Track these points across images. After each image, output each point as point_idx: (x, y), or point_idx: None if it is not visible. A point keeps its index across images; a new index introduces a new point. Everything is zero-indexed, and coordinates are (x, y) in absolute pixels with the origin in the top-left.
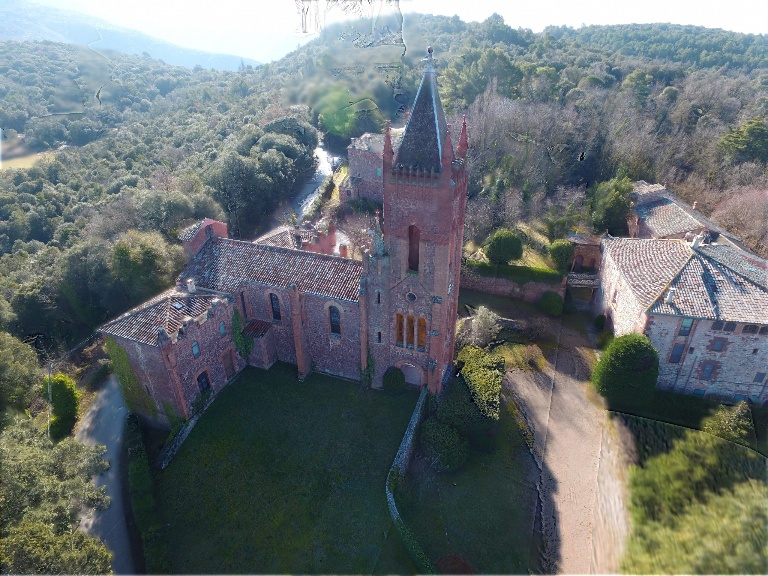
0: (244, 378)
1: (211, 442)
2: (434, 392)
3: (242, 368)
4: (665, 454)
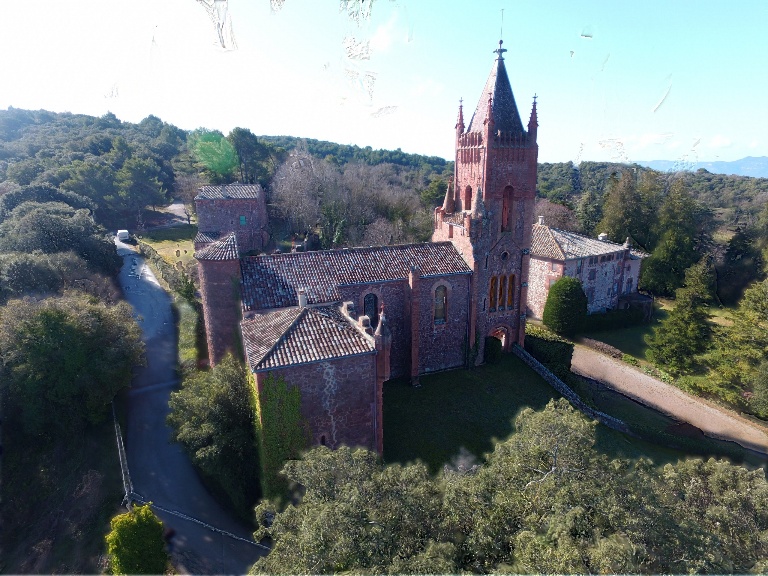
0: None
1: None
2: (523, 346)
3: None
4: None
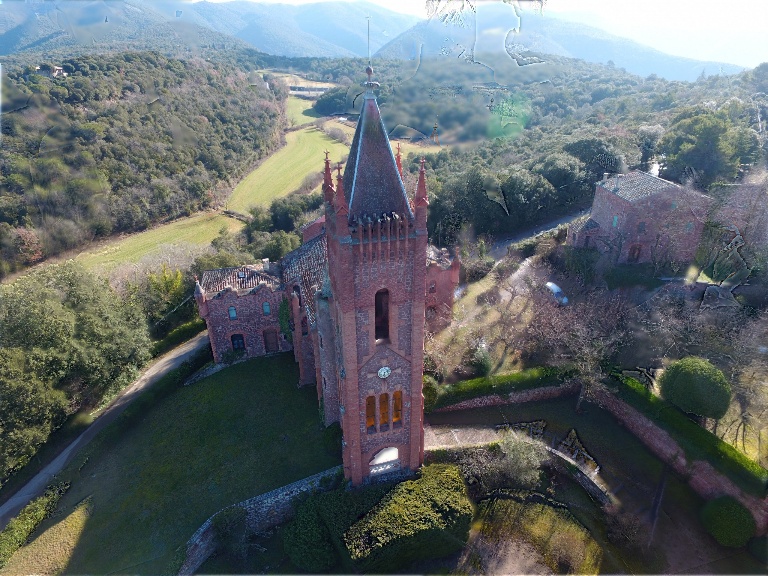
0: (278, 358)
1: (211, 387)
2: (346, 477)
3: (287, 350)
4: None
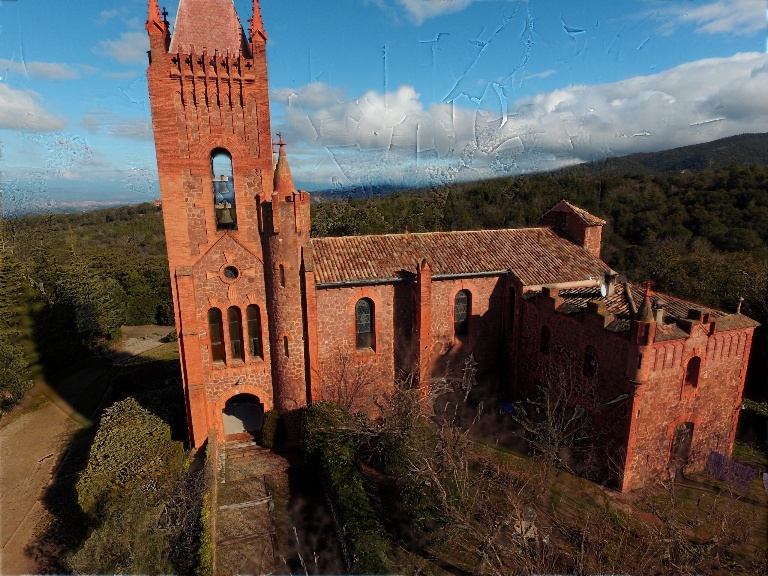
0: None
1: None
2: None
3: None
4: (65, 136)
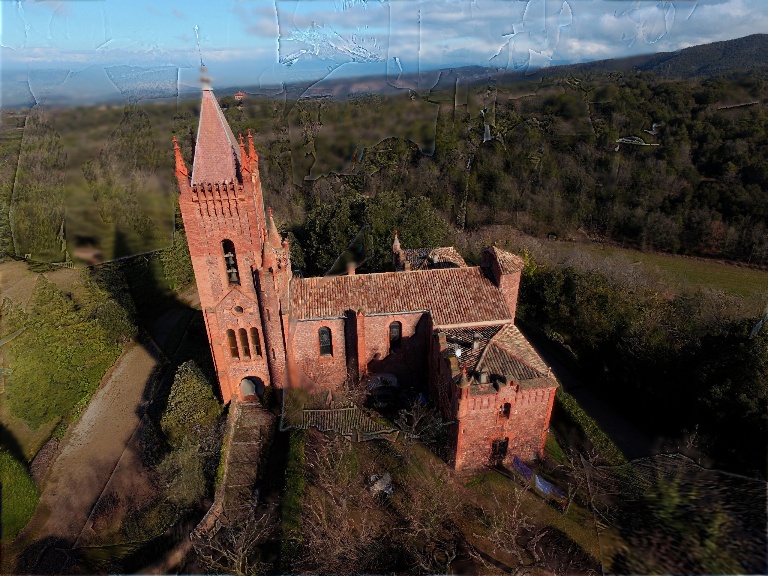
0: None
1: None
2: None
3: None
4: None
